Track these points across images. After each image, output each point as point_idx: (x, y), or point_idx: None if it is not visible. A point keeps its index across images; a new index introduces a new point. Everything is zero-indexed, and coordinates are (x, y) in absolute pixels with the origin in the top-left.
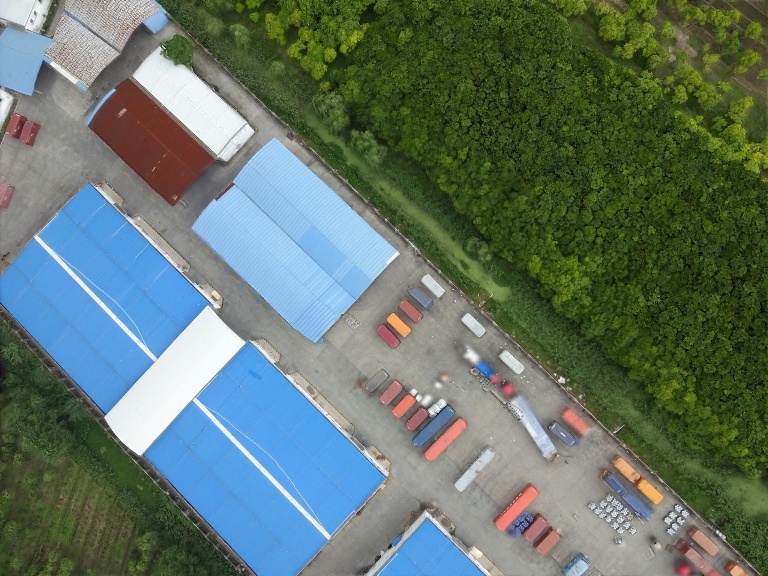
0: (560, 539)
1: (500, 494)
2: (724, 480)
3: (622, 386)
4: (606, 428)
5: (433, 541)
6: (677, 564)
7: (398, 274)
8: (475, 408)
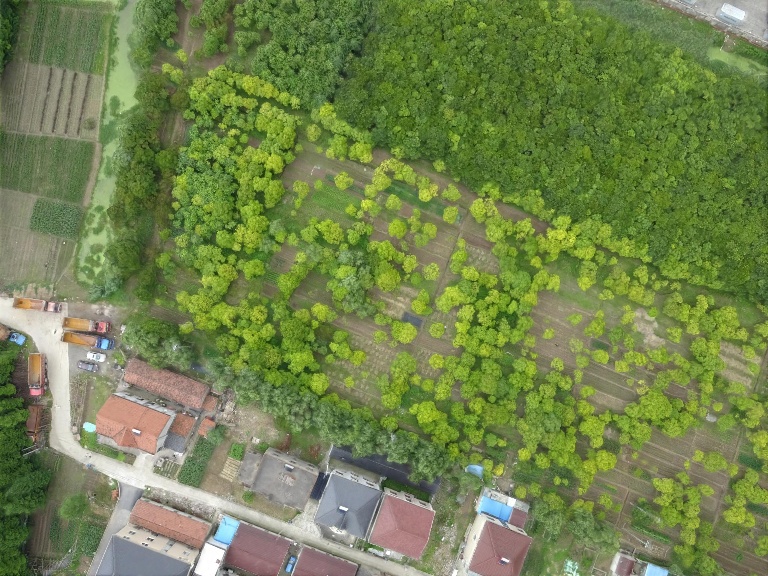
0: None
1: None
2: None
3: (588, 6)
4: None
5: None
6: None
7: None
8: None
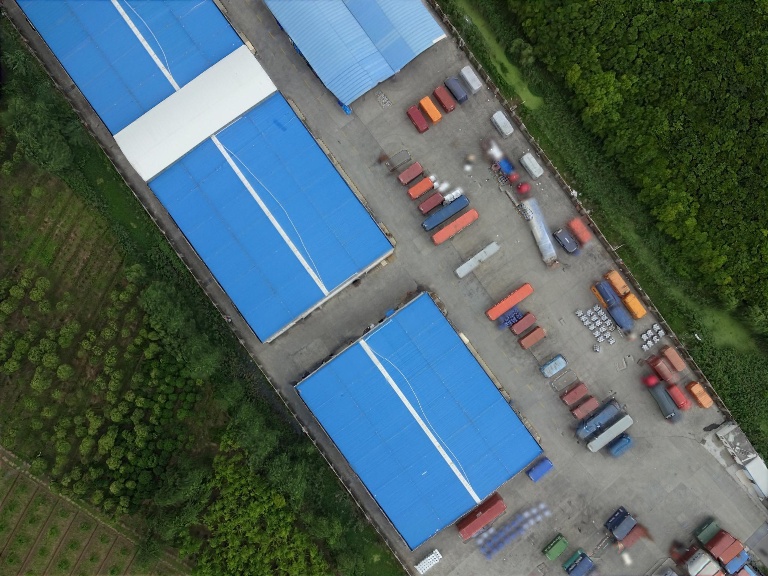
0: (544, 339)
1: (496, 289)
2: (701, 309)
3: (629, 207)
4: (607, 243)
5: (428, 315)
6: (645, 378)
7: (438, 63)
8: (488, 205)
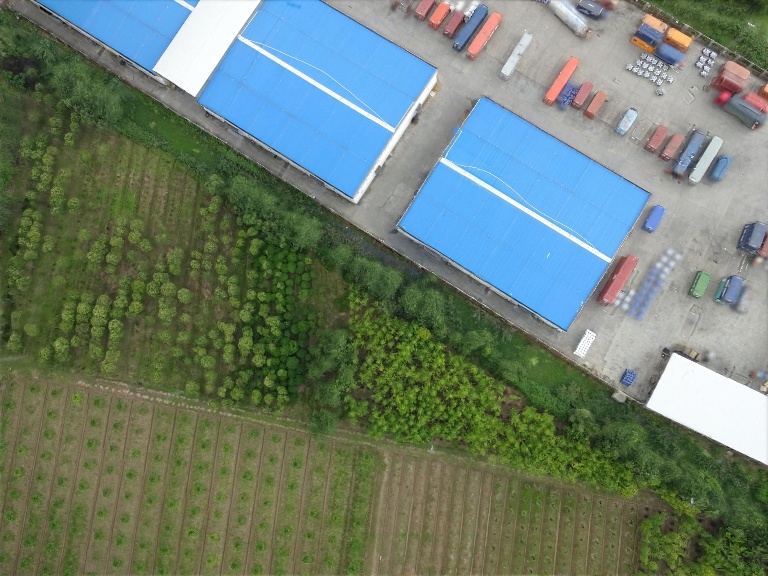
0: (607, 103)
1: (544, 77)
2: (741, 20)
3: None
4: None
5: (492, 115)
6: (716, 101)
7: None
8: (505, 7)
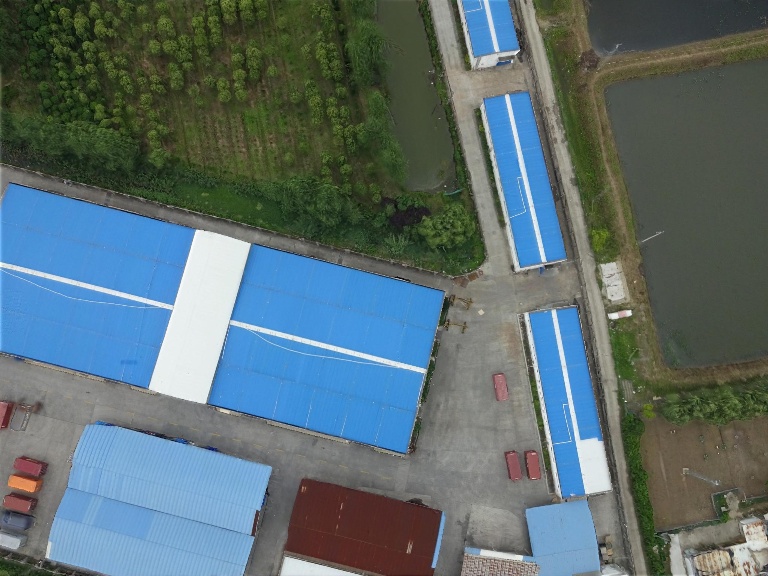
0: None
1: None
2: None
3: None
4: None
5: None
6: None
7: None
8: None
